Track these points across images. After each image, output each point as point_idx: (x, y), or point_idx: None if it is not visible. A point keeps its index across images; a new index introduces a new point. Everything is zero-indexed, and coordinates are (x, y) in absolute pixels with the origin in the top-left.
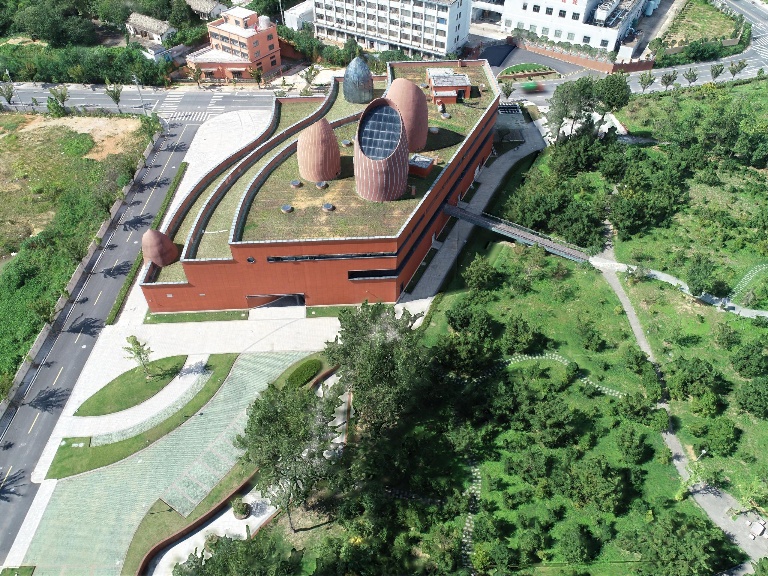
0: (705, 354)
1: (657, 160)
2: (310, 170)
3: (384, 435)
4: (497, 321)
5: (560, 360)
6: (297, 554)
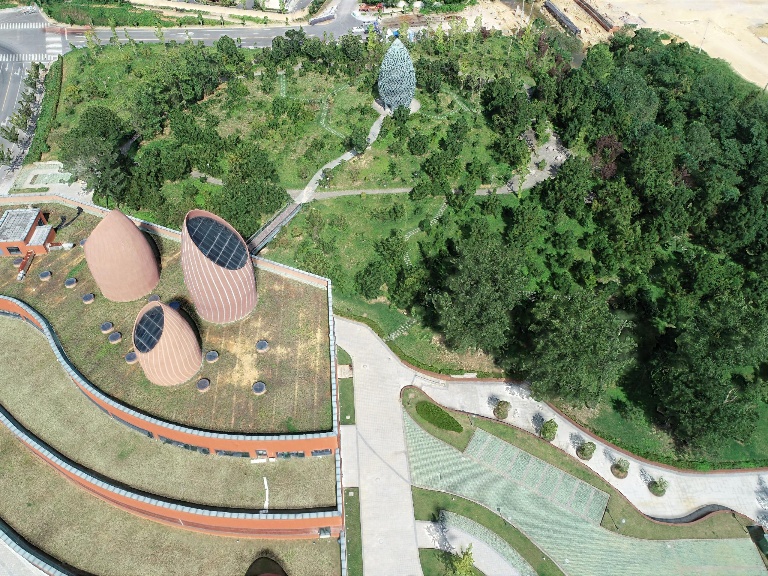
0: (406, 165)
1: (164, 145)
2: (194, 359)
3: (491, 351)
4: (366, 269)
5: (409, 236)
6: (681, 319)
